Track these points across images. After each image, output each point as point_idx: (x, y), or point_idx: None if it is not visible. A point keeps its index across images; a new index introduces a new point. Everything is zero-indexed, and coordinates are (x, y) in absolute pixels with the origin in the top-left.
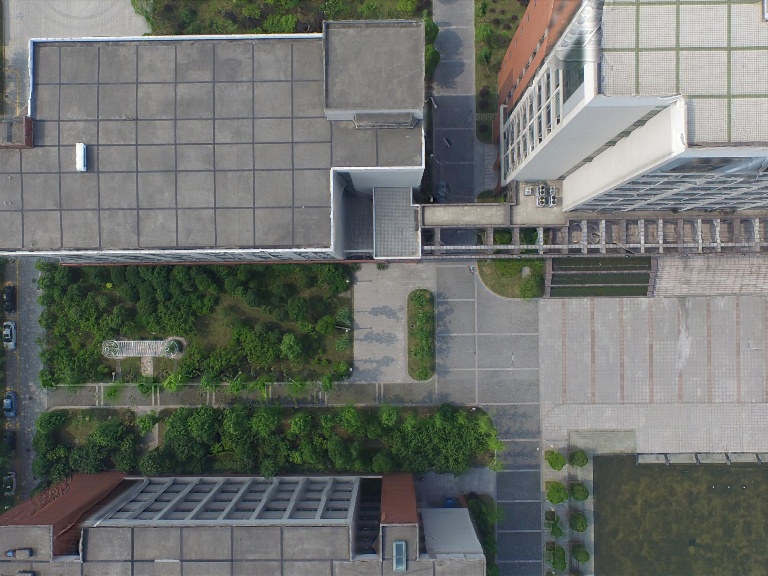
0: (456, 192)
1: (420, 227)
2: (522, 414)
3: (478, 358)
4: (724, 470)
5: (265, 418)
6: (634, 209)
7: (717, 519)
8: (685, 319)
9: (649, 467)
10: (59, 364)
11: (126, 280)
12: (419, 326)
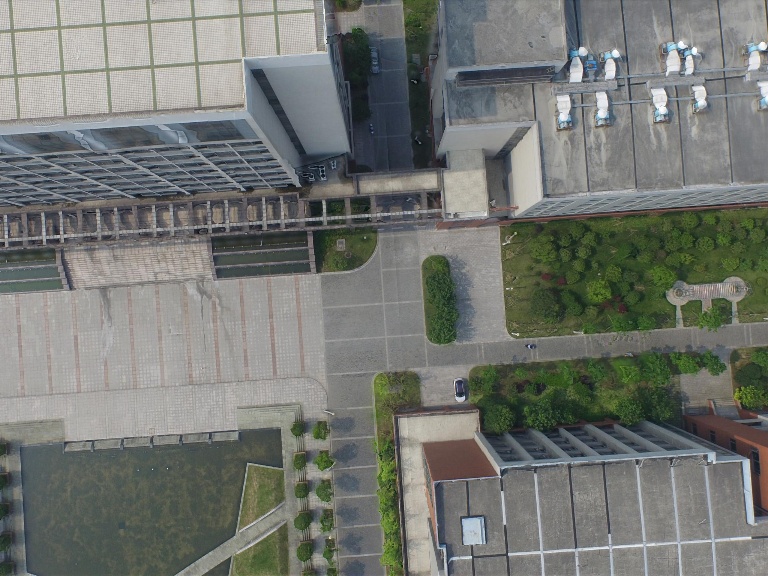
0: None
1: None
2: None
3: None
4: (149, 453)
5: None
6: None
7: (145, 501)
8: (107, 309)
9: (77, 455)
10: None
11: None
12: None
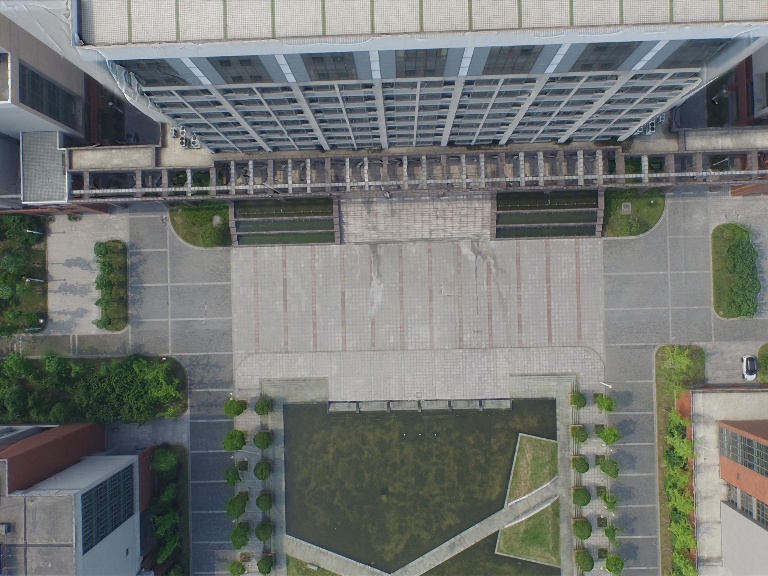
0: (147, 142)
1: (66, 171)
2: (215, 364)
3: (171, 308)
4: (416, 418)
5: None
6: (278, 148)
7: (409, 467)
8: (377, 266)
9: (341, 415)
10: None
11: None
12: (101, 275)
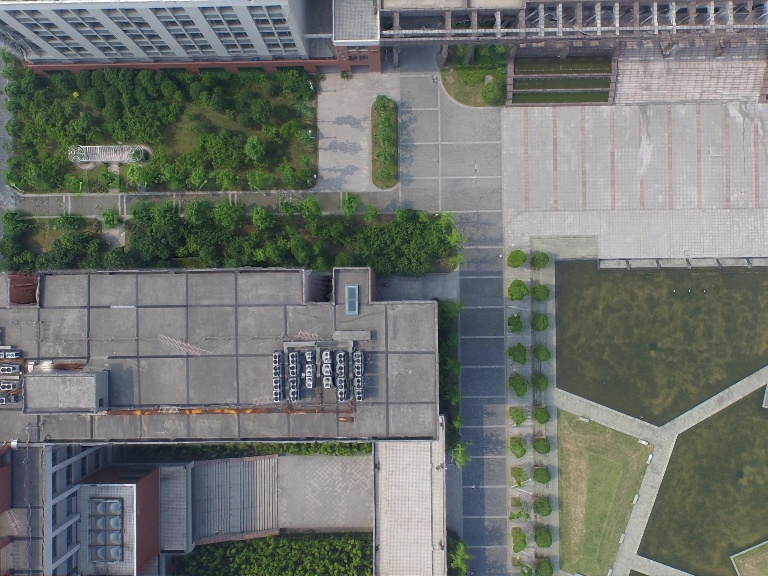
0: None
1: (379, 10)
2: (485, 222)
3: (441, 166)
4: (685, 275)
5: (227, 207)
6: None
7: (678, 323)
8: (646, 127)
9: (611, 272)
10: (26, 171)
11: (92, 85)
12: (382, 128)
